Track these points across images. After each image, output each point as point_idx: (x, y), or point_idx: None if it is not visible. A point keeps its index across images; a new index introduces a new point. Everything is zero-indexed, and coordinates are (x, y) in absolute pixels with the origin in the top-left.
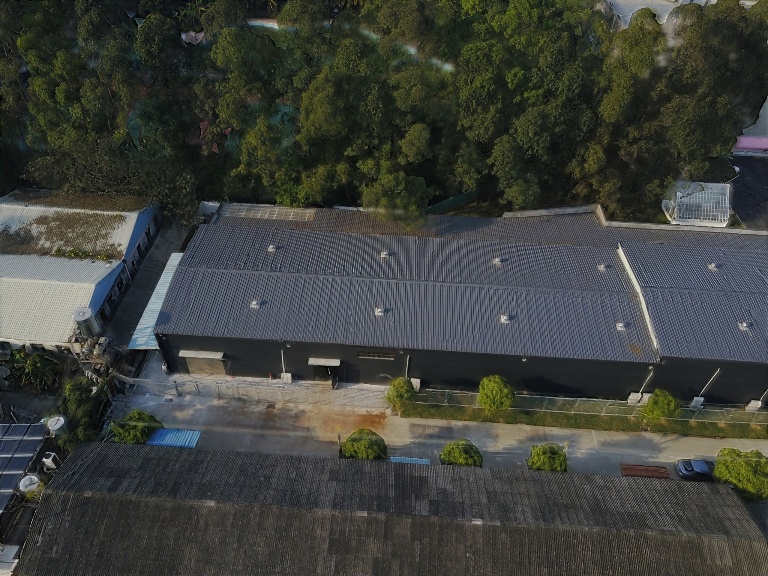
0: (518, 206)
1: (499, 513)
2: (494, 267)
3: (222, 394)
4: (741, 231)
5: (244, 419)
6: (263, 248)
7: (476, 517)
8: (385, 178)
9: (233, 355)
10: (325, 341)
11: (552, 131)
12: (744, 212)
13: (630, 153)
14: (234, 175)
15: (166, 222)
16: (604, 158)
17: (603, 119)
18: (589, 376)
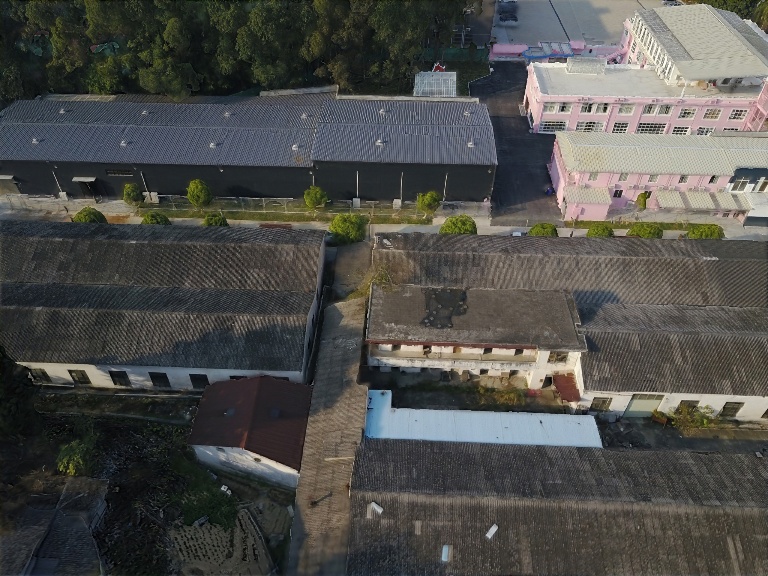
0: (265, 84)
1: (151, 239)
2: (223, 118)
3: (14, 206)
4: (441, 99)
5: (26, 220)
6: (57, 111)
7: (134, 240)
8: (156, 62)
9: (21, 178)
10: (78, 160)
11: (278, 22)
12: (478, 97)
13: (341, 38)
14: (48, 67)
15: (4, 107)
16: (321, 42)
17: (316, 11)
18: (273, 183)
